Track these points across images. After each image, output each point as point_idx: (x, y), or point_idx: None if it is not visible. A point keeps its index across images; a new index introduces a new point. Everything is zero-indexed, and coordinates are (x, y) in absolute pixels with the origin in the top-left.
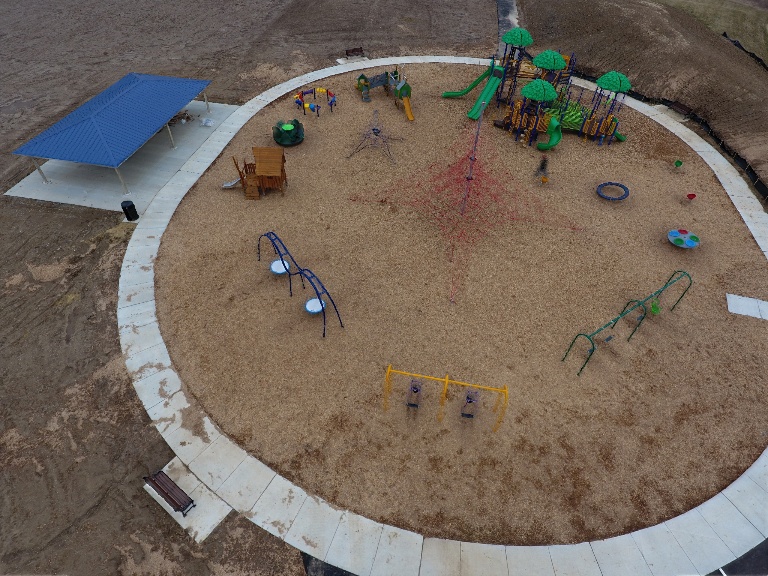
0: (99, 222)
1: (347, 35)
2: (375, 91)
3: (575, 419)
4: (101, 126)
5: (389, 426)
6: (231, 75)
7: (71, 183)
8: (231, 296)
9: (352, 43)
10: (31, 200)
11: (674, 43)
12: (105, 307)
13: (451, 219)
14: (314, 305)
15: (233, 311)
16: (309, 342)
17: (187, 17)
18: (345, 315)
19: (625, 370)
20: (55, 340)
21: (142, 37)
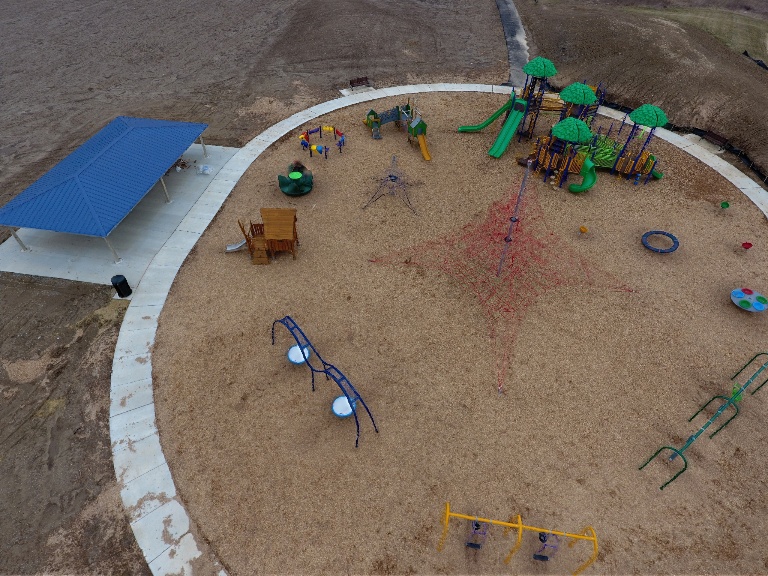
0: (86, 300)
1: (349, 62)
2: (385, 126)
3: (668, 553)
4: (86, 187)
5: (446, 574)
6: (228, 111)
7: (53, 250)
8: (243, 394)
9: (355, 71)
10: (7, 274)
11: (698, 66)
12: (95, 415)
13: (486, 282)
14: (342, 405)
15: (247, 415)
16: (339, 454)
17: (177, 45)
18: (378, 415)
19: (714, 479)
20: (35, 465)
21: (130, 69)
